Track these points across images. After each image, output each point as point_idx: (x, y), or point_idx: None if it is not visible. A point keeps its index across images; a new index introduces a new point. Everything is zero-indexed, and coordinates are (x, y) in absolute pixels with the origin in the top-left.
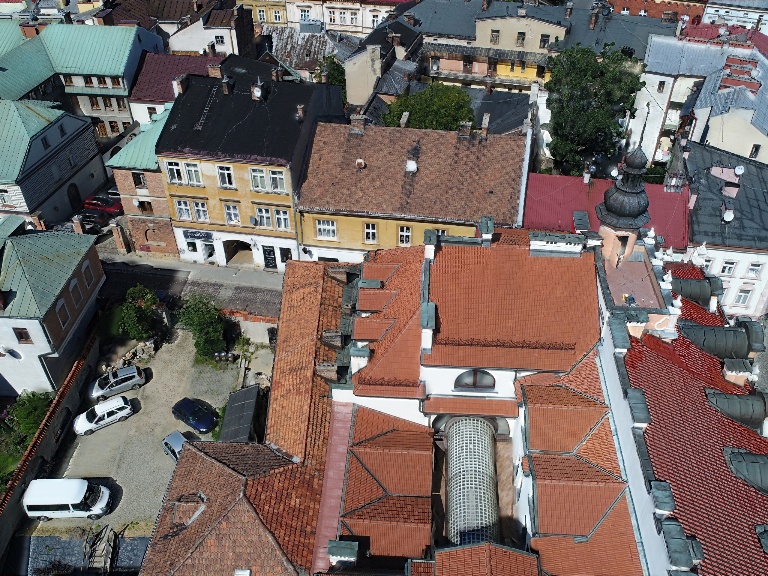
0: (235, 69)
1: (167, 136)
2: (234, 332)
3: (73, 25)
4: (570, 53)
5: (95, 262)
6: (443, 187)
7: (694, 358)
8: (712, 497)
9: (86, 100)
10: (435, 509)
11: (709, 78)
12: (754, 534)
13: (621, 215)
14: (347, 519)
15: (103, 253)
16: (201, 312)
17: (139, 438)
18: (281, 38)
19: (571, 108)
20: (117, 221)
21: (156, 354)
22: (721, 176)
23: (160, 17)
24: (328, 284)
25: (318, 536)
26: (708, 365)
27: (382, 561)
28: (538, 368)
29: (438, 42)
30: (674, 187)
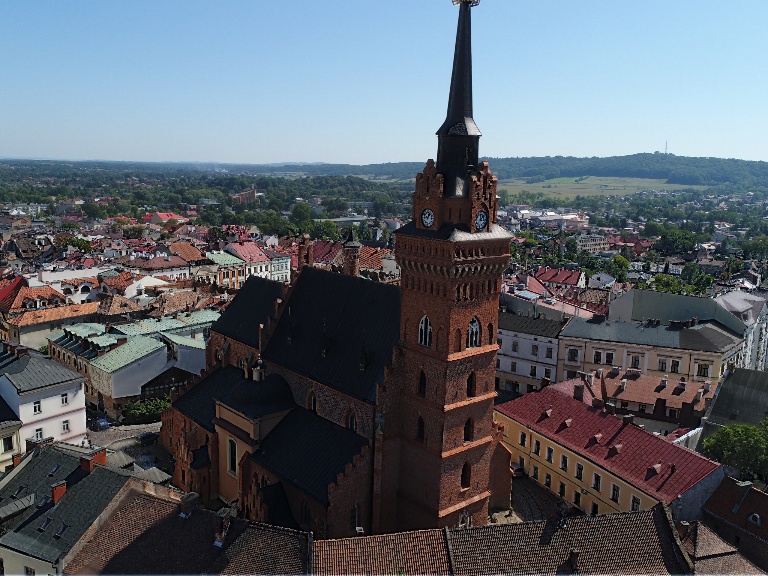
0: None
1: None
2: None
3: None
4: None
5: None
6: None
7: None
8: None
9: None
10: None
11: None
12: None
13: None
14: None
15: None
16: None
17: None
18: None
19: None
20: None
21: None
22: None
23: None
24: None
25: None
26: None
27: None
28: None
29: None
30: None
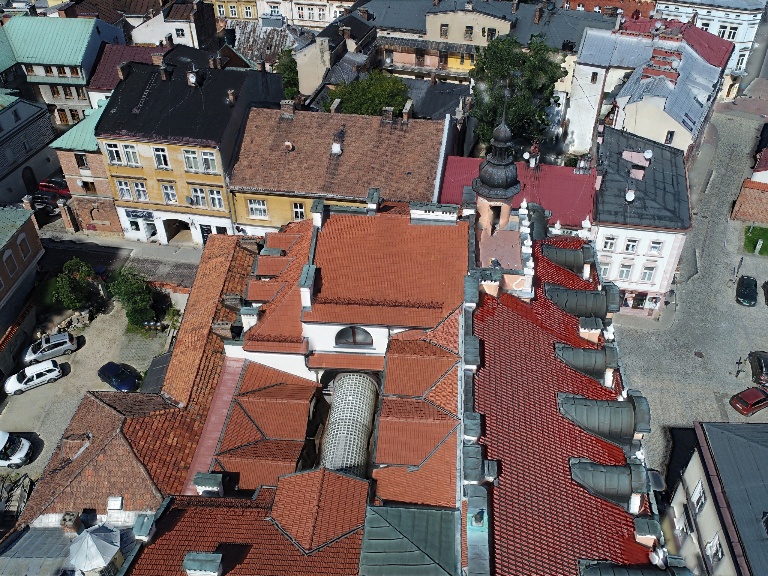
0: (180, 58)
1: (106, 119)
2: (165, 303)
3: (35, 17)
4: (492, 43)
5: (32, 236)
6: (365, 168)
7: (552, 317)
8: (531, 431)
9: (47, 89)
10: (306, 451)
11: (637, 69)
12: (566, 464)
13: (492, 186)
14: (221, 457)
15: (52, 232)
16: (129, 282)
17: (65, 398)
18: (244, 32)
19: (492, 95)
20: (64, 201)
21: (91, 323)
22: (632, 160)
23: (127, 11)
24: (239, 254)
25: (191, 471)
26: (565, 323)
27: (249, 494)
28: (407, 325)
29: (391, 36)
30: (583, 169)
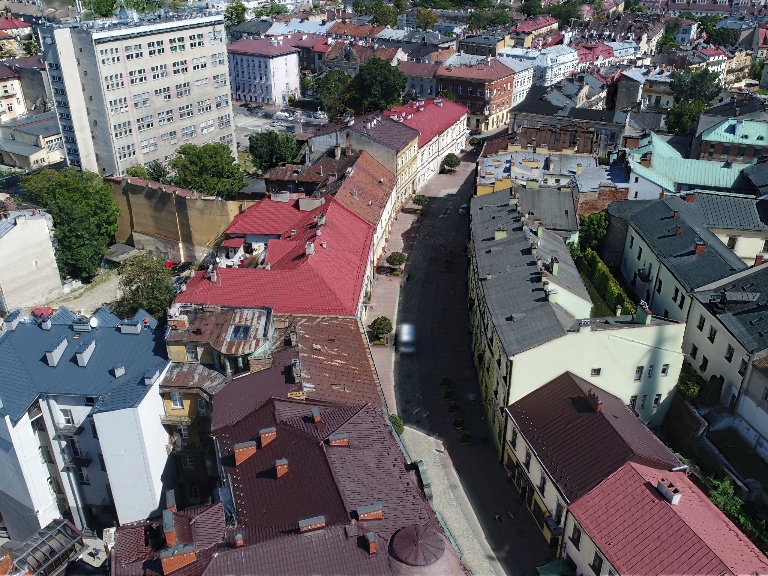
0: None
1: None
2: None
3: (654, 145)
4: None
5: None
6: None
7: None
8: None
9: None
10: None
11: None
12: None
13: None
14: None
15: None
16: None
17: None
18: None
19: None
20: None
21: None
22: None
23: None
24: None
25: None
26: None
27: None
28: None
29: None
30: None
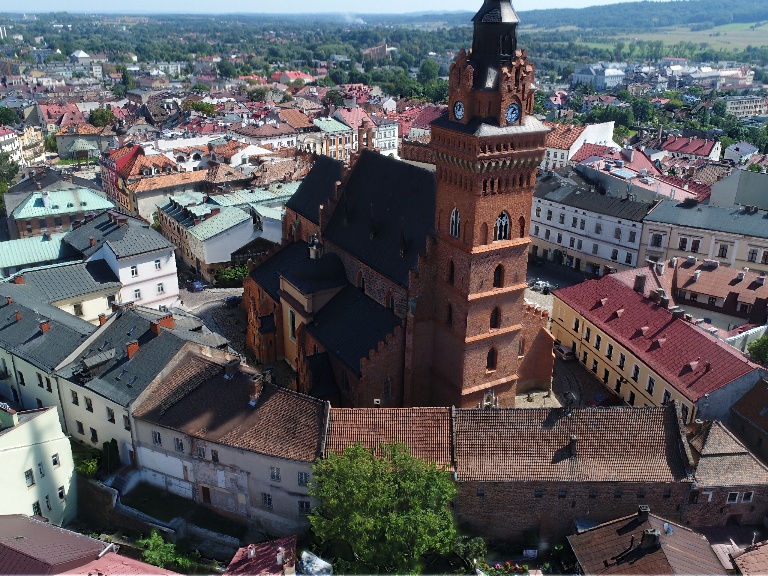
0: None
1: None
2: None
3: None
4: None
5: None
6: None
7: None
8: None
9: None
10: None
11: None
12: None
13: None
14: None
15: None
16: None
17: None
18: None
19: None
20: None
21: None
22: None
23: None
24: None
25: None
26: None
27: None
28: None
29: None
30: None
